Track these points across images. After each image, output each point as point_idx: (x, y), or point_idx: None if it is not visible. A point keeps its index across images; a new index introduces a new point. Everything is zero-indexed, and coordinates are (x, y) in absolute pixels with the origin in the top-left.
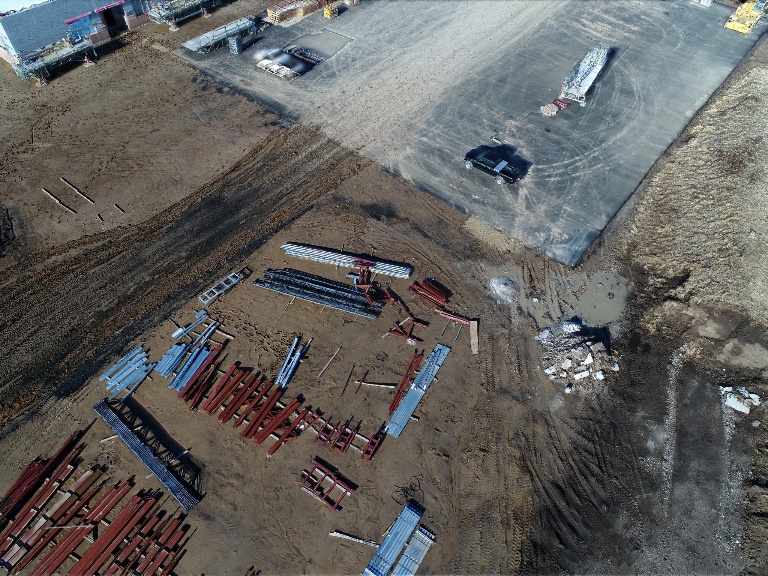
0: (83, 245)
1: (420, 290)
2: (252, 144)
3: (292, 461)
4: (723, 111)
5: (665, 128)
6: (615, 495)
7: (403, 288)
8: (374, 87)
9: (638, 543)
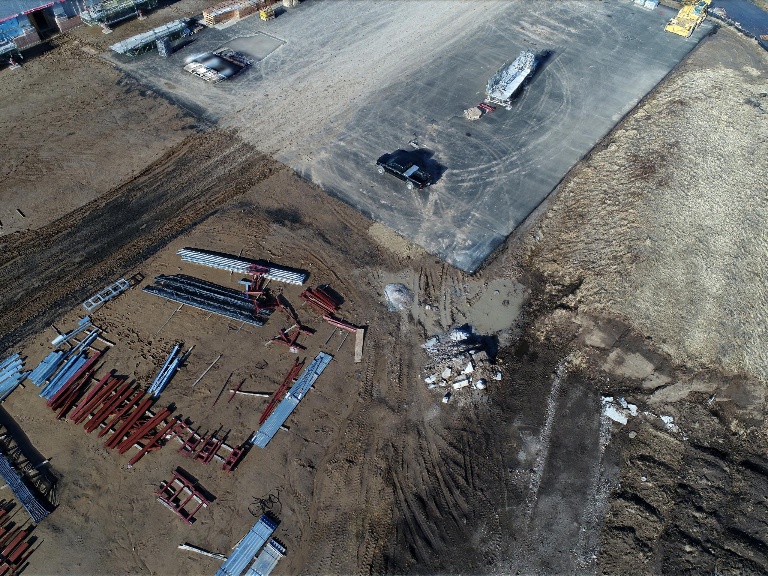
0: None
1: (311, 297)
2: (166, 148)
3: (153, 472)
4: (650, 115)
5: (589, 132)
6: (477, 508)
7: (295, 295)
8: (299, 90)
9: (493, 557)
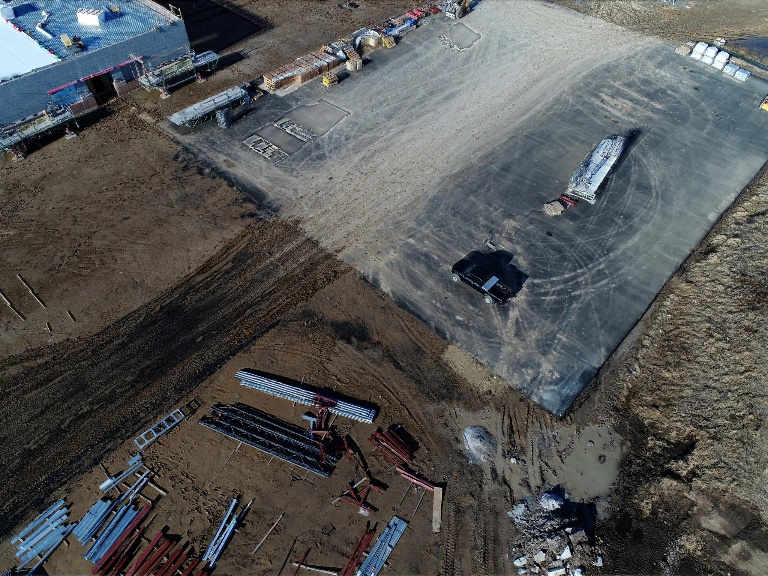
0: (25, 361)
1: (382, 441)
2: (225, 240)
3: None
4: (751, 215)
5: (683, 235)
6: None
7: (364, 436)
8: (364, 173)
9: None
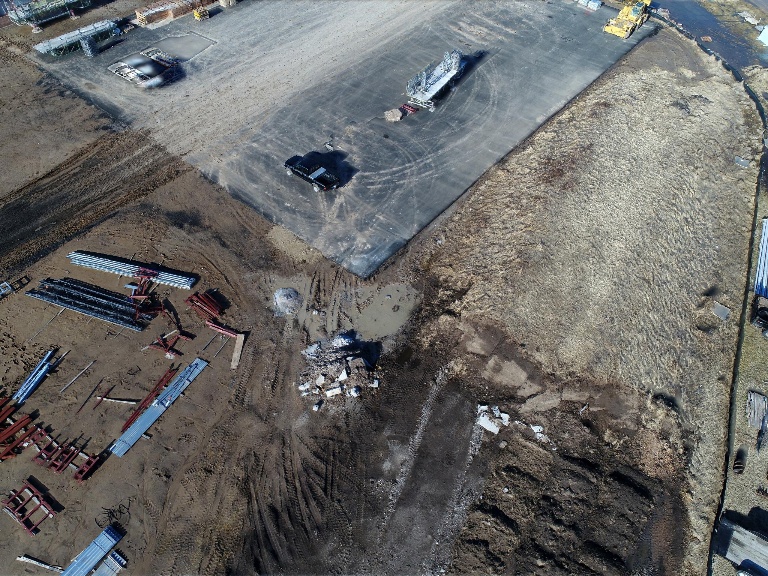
0: None
1: (197, 301)
2: (76, 149)
3: (4, 481)
4: None
5: (510, 134)
6: (332, 519)
7: (181, 299)
8: (221, 91)
9: (338, 571)
